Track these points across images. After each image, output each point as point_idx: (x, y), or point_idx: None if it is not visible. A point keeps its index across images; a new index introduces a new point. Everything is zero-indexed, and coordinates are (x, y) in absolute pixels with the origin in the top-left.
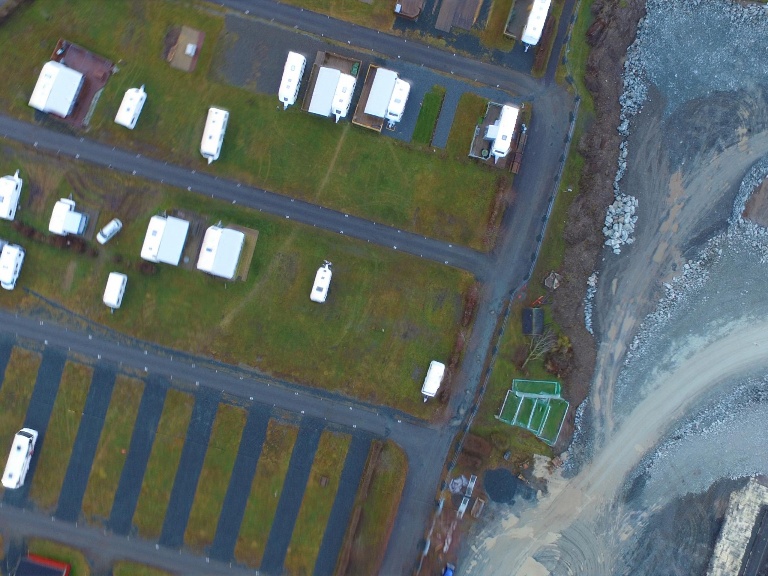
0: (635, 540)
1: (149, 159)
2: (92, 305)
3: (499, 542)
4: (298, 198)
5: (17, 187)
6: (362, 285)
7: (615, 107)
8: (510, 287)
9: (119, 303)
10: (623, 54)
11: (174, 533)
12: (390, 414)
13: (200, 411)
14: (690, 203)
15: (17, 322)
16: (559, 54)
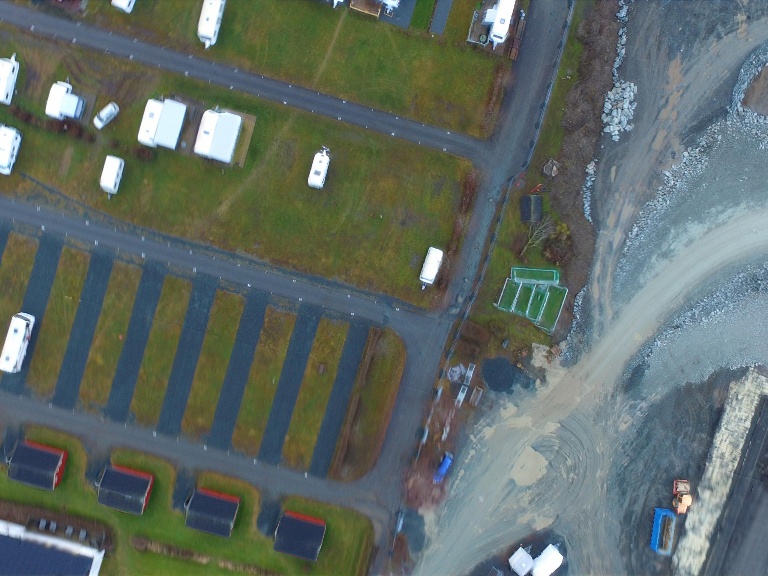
0: (634, 430)
1: (146, 44)
2: (89, 191)
3: (498, 431)
4: (296, 84)
5: (14, 70)
6: (360, 172)
7: None
8: (508, 175)
9: (116, 188)
10: None
11: (172, 420)
12: (388, 302)
13: (197, 298)
14: (689, 90)
15: (14, 208)
16: None
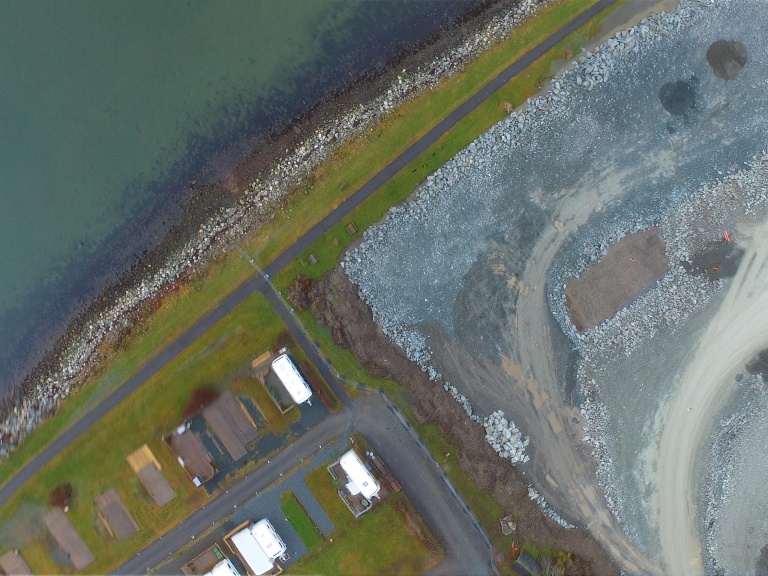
0: None
1: None
2: None
3: None
4: None
5: None
6: None
7: (412, 368)
8: (485, 562)
9: None
10: (375, 328)
11: None
12: None
13: None
14: (536, 369)
15: None
16: (334, 379)
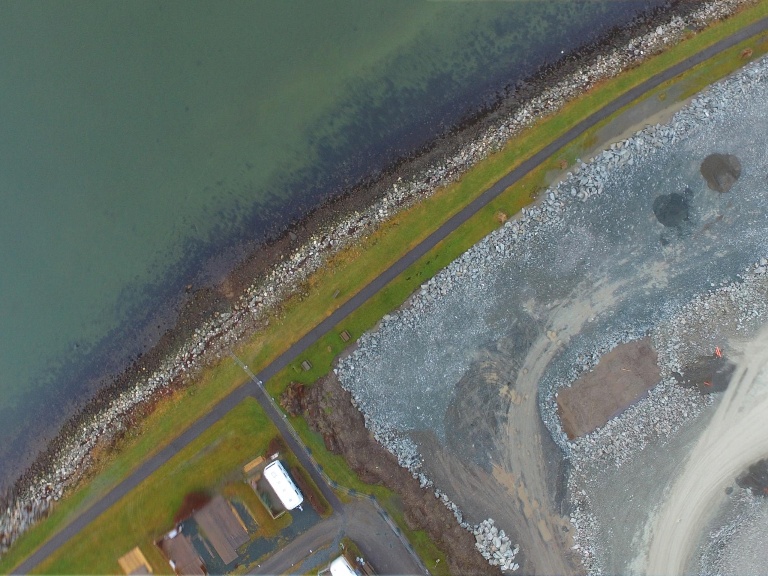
0: None
1: None
2: None
3: None
4: None
5: None
6: None
7: (403, 474)
8: None
9: None
10: (367, 434)
11: None
12: None
13: None
14: (526, 477)
15: None
16: (326, 484)
